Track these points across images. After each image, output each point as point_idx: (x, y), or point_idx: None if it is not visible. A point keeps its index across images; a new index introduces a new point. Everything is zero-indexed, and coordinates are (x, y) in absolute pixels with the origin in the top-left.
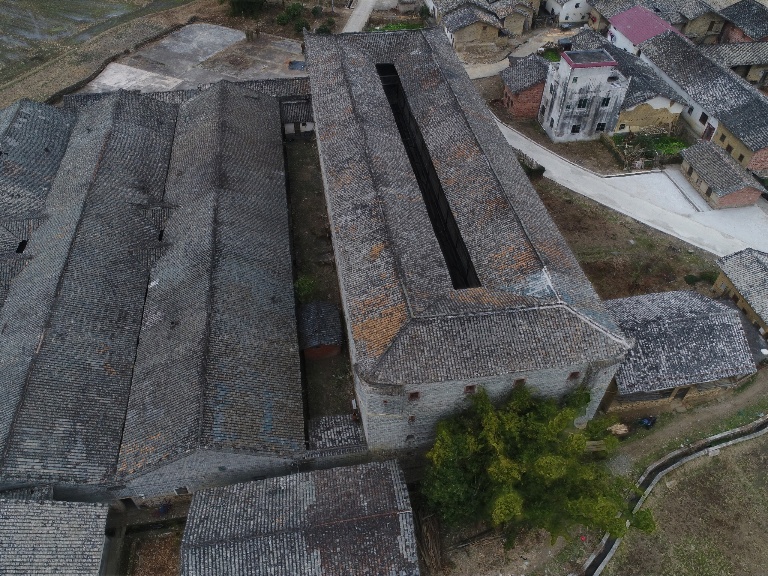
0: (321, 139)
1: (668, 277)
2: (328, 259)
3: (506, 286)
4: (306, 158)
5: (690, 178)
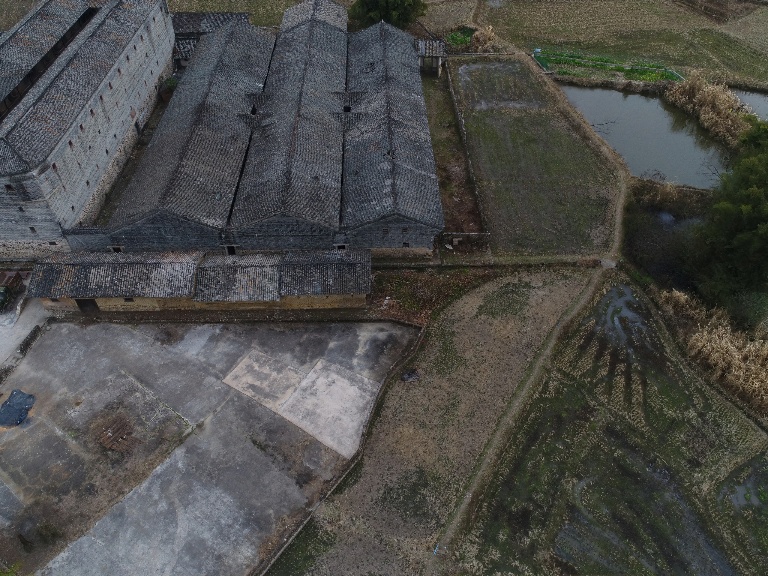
0: (110, 66)
1: None
2: (149, 131)
3: (80, 0)
4: None
5: None
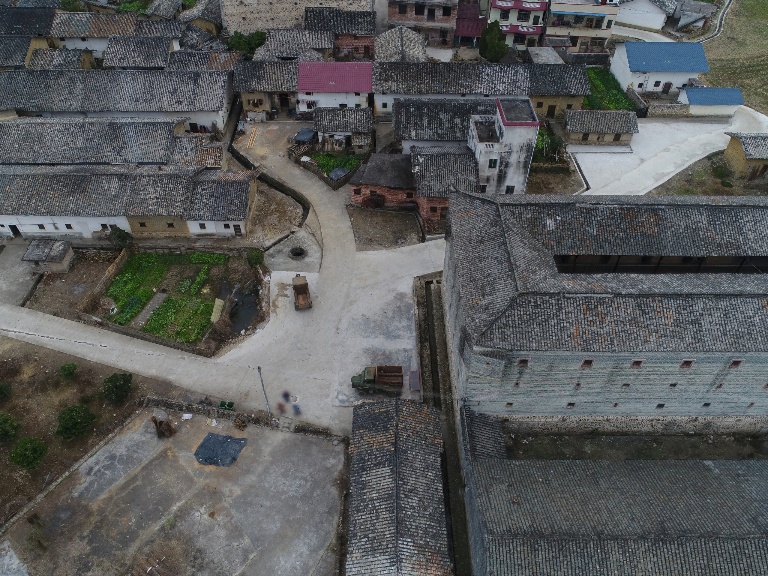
0: None
1: (728, 194)
2: None
3: None
4: (564, 453)
5: (588, 142)
